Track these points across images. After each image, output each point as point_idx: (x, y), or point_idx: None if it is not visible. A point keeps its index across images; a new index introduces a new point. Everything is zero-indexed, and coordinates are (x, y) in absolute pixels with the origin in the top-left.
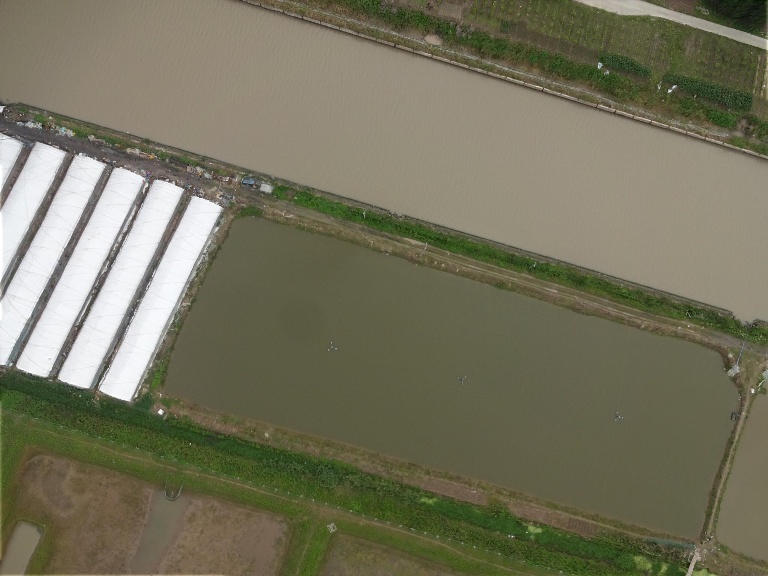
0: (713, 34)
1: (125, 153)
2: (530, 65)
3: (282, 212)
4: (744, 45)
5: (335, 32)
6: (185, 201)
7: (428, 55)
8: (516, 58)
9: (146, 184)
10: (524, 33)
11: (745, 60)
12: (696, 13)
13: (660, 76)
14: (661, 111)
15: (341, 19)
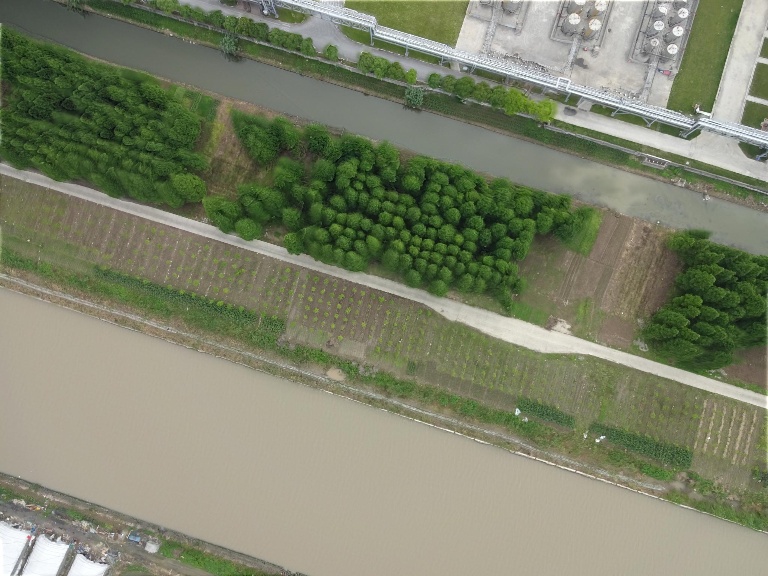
0: (651, 375)
1: (12, 503)
2: (441, 405)
3: (168, 571)
4: (688, 387)
5: (232, 364)
6: (71, 555)
7: (329, 392)
8: (424, 401)
9: (32, 537)
10: (433, 375)
11: (687, 409)
12: (633, 349)
13: (586, 425)
14: (588, 459)
15: (237, 353)
